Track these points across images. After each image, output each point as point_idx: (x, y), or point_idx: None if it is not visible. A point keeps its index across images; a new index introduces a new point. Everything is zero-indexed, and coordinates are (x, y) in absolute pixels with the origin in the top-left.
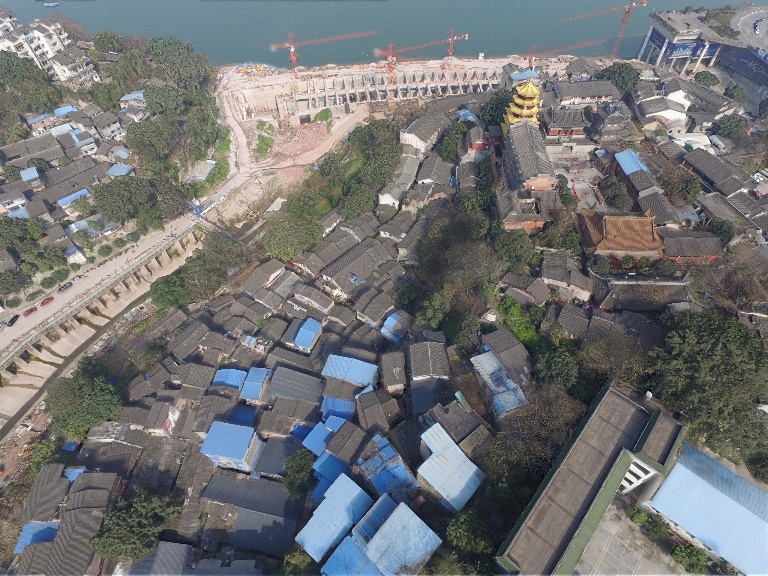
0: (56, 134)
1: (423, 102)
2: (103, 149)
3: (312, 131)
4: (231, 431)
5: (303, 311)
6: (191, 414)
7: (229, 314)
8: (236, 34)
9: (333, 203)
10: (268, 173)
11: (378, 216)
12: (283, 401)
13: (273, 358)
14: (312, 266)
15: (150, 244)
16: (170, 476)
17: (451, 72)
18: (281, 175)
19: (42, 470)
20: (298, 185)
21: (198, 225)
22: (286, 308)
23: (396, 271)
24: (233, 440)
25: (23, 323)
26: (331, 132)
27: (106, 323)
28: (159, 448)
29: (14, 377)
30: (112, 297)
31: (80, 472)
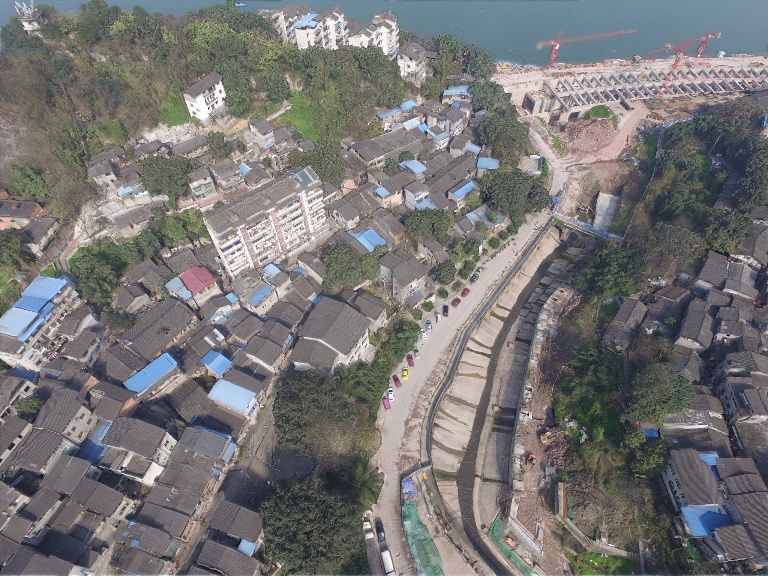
0: (409, 128)
1: (696, 99)
2: (458, 143)
3: (598, 127)
4: None
5: None
6: None
7: (707, 304)
8: None
9: (701, 197)
10: (582, 168)
11: None
12: None
13: None
14: (760, 258)
15: (525, 237)
16: None
17: (697, 70)
18: (596, 170)
19: (673, 455)
20: (615, 180)
21: (558, 219)
22: None
23: None
24: None
25: (456, 313)
26: (618, 128)
27: (508, 314)
28: (758, 435)
29: (460, 366)
30: (507, 289)
31: (716, 457)
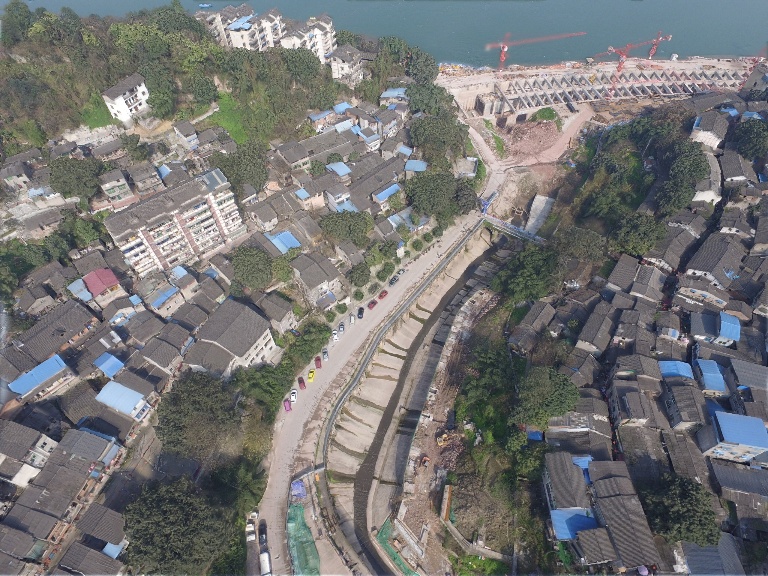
0: (341, 130)
1: (643, 102)
2: (389, 145)
3: (542, 130)
4: (740, 421)
5: (699, 305)
6: (653, 405)
7: (612, 307)
8: (404, 35)
9: (628, 200)
10: (521, 171)
11: (695, 213)
12: (761, 392)
13: (706, 350)
14: (671, 261)
15: (452, 239)
16: (665, 465)
17: (649, 73)
18: (534, 173)
19: (548, 458)
20: (553, 183)
21: (487, 221)
22: (677, 302)
23: (766, 266)
24: (749, 430)
25: (371, 315)
26: (562, 131)
27: (429, 317)
28: (638, 438)
29: (372, 369)
30: (429, 291)
31: (589, 460)
